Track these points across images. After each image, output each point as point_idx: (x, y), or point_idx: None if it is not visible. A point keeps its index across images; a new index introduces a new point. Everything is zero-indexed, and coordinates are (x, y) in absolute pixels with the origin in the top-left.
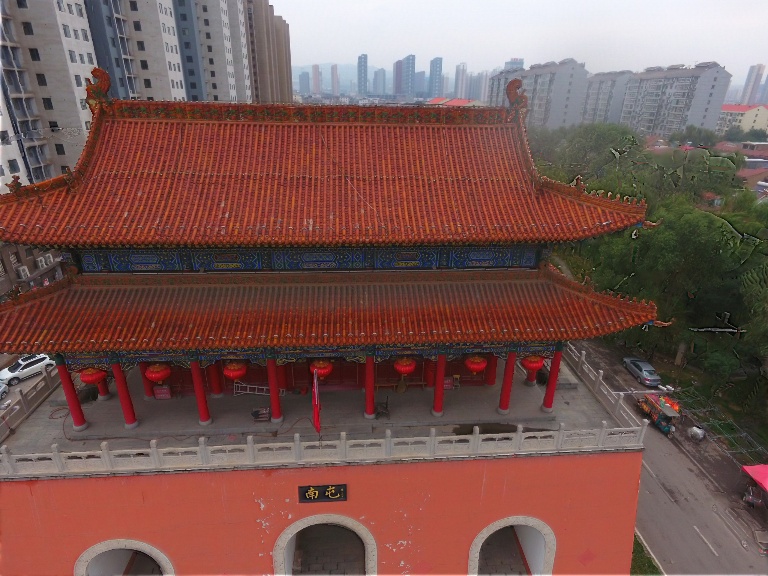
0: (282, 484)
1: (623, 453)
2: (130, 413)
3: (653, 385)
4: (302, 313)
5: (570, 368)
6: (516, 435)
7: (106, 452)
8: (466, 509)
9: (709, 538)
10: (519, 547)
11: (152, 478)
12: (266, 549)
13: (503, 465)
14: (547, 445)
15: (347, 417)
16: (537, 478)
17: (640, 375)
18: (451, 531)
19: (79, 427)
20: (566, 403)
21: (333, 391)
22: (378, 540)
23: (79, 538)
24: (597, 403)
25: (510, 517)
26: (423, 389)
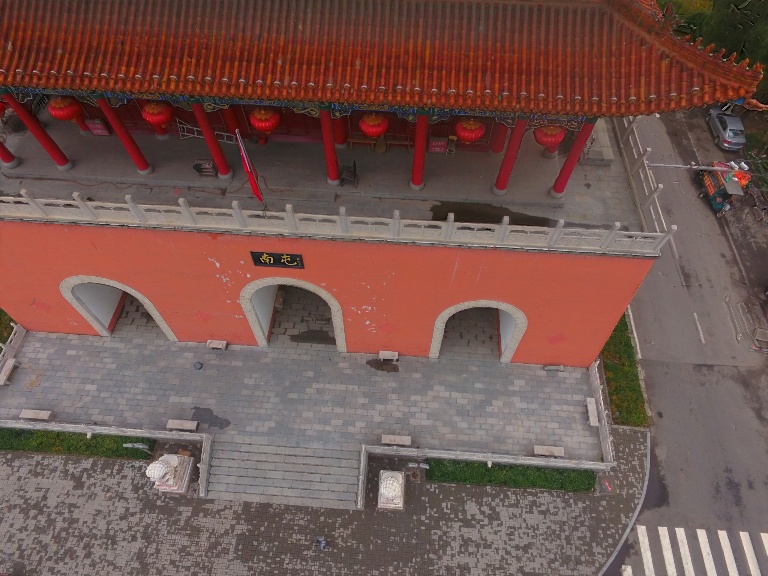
0: (232, 248)
1: (630, 258)
2: (56, 153)
3: (731, 149)
4: (212, 41)
5: (614, 135)
6: (500, 227)
7: (30, 200)
8: (434, 289)
9: (704, 326)
10: (497, 313)
11: (93, 229)
12: (233, 298)
13: (480, 255)
14: (537, 241)
15: (308, 180)
16: (518, 271)
17: (721, 135)
18: (417, 304)
19: (8, 164)
20: (586, 185)
21: (298, 143)
22: (342, 303)
23: (51, 271)
24: (627, 189)
25: (481, 300)
26: (408, 150)
